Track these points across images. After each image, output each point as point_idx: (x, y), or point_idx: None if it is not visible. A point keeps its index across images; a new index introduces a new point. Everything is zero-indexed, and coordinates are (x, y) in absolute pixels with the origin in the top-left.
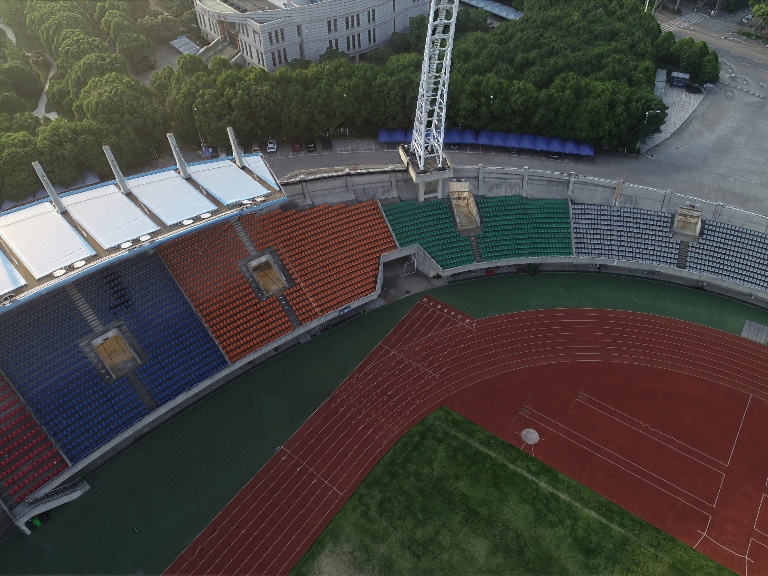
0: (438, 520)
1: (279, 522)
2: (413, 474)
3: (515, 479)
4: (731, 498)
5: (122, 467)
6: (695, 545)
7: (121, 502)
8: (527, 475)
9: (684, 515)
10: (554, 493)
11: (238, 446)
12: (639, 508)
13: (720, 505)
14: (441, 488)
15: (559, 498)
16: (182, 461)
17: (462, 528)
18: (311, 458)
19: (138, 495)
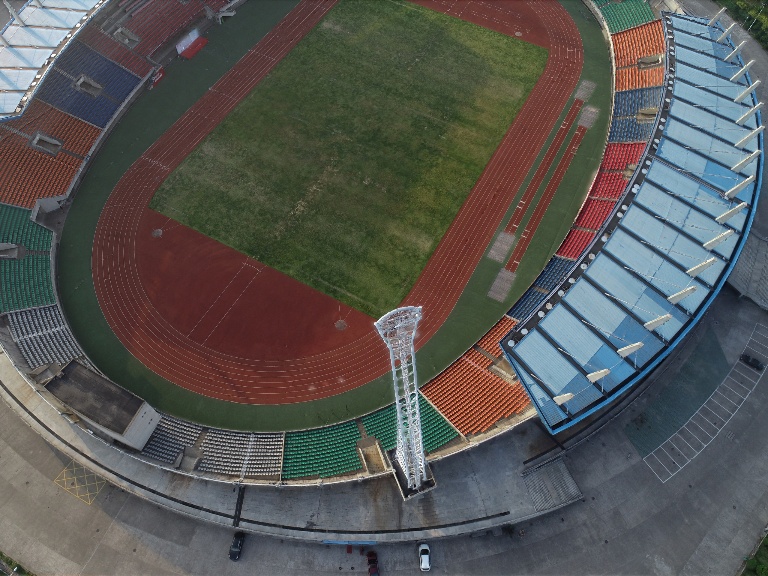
0: (361, 13)
1: (307, 17)
2: (352, 3)
3: (387, 2)
4: (459, 2)
5: (245, 8)
6: (445, 13)
7: (249, 16)
8: (392, 1)
9: (443, 7)
10: (401, 5)
11: (286, 0)
12: (429, 6)
13: (455, 4)
14: (362, 6)
15: (402, 6)
16: (267, 5)
17: (369, 14)
18: (314, 2)
19: (255, 14)
